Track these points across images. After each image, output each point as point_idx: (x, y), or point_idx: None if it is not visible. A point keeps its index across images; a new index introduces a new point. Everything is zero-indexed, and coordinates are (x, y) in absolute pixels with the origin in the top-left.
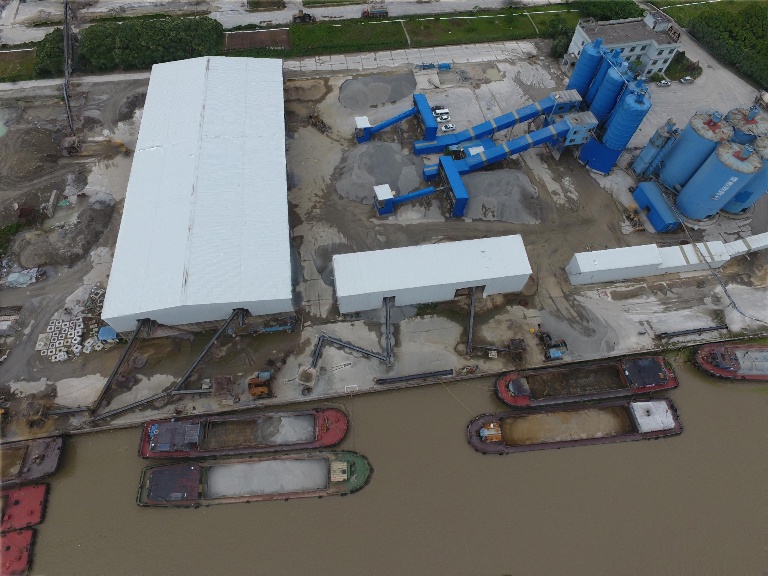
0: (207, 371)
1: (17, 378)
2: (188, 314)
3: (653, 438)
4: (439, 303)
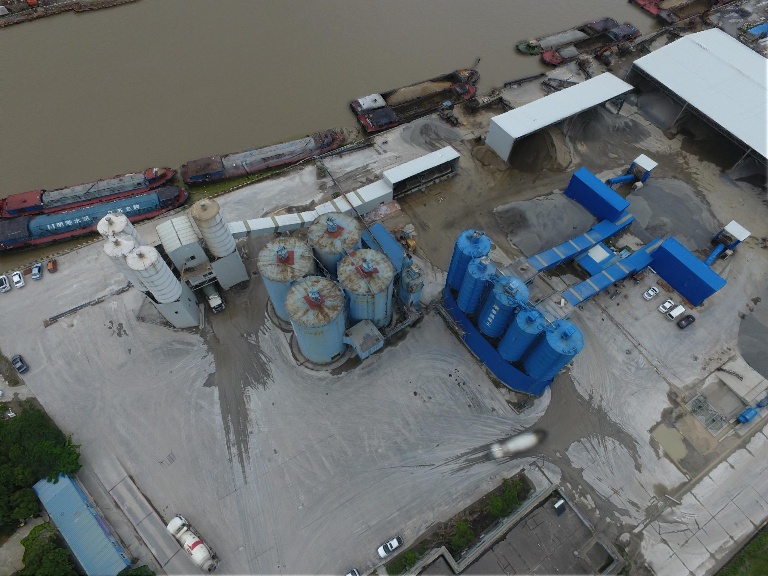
0: None
1: None
2: None
3: None
4: None
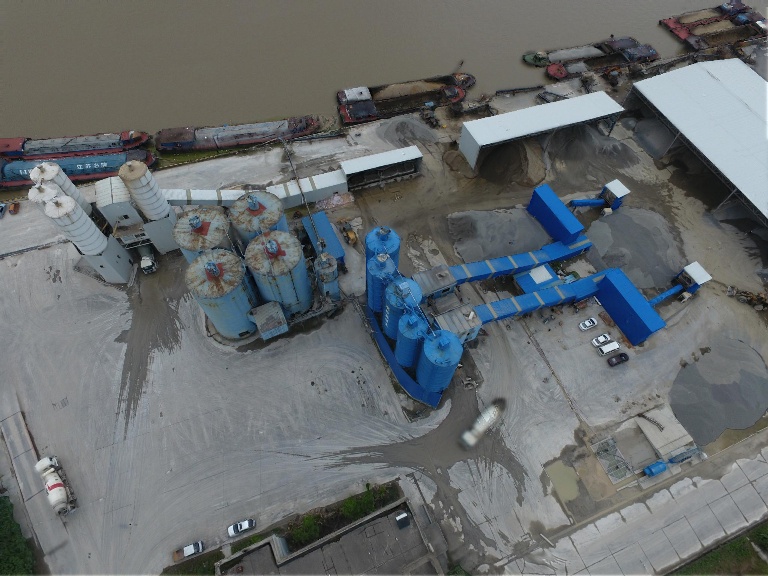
0: None
1: (753, 68)
2: None
3: None
4: None
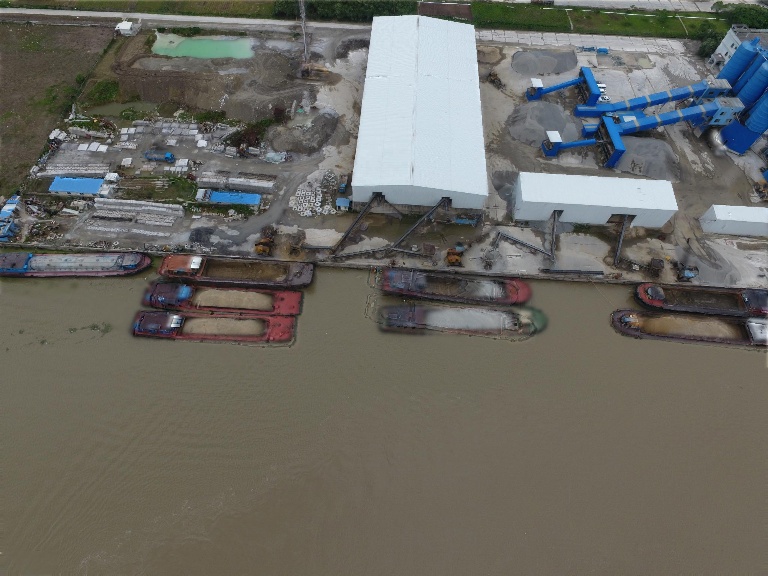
0: (412, 241)
1: (277, 222)
2: (410, 195)
3: (762, 351)
4: (592, 226)
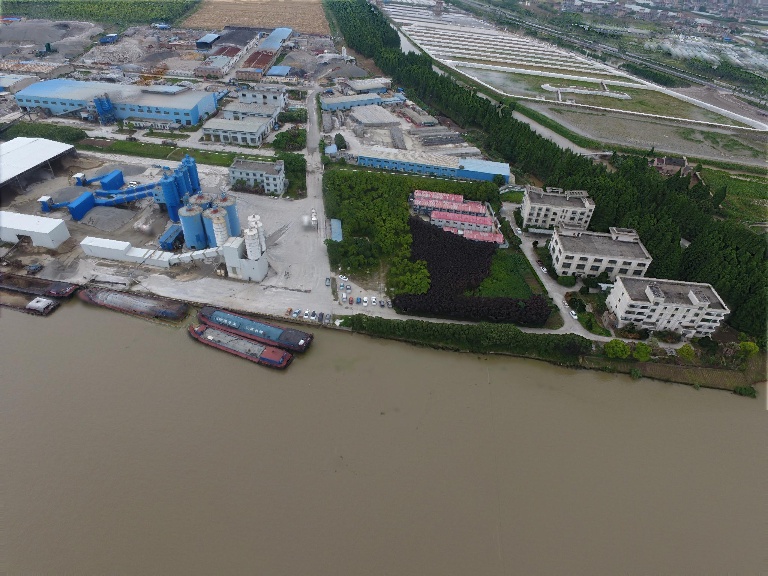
0: None
1: None
2: None
3: (30, 313)
4: None
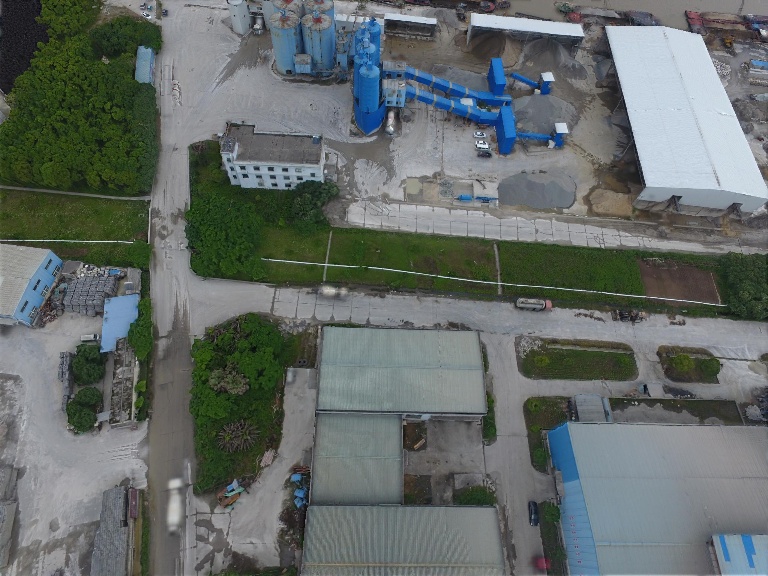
0: None
1: (730, 57)
2: None
3: None
4: None
